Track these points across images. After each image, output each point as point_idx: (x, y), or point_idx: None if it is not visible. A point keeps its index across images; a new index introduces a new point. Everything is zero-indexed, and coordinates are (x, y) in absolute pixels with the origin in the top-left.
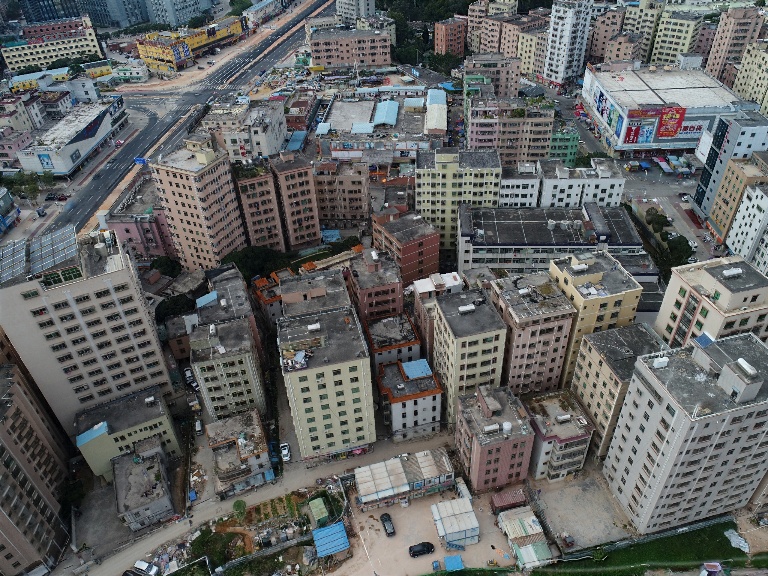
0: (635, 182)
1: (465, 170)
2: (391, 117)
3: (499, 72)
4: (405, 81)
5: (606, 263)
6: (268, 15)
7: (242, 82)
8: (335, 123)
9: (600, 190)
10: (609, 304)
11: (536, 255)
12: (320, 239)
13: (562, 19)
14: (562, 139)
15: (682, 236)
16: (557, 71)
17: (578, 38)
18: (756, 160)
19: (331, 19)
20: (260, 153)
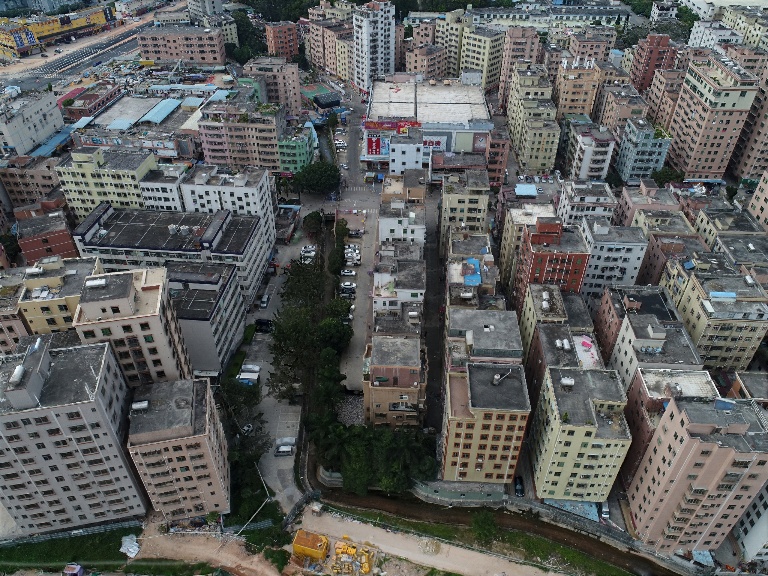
0: (363, 193)
1: (101, 170)
2: (160, 115)
3: (276, 77)
4: (224, 80)
5: (91, 268)
6: (145, 7)
7: (73, 72)
8: (106, 118)
9: (236, 198)
10: (52, 308)
11: (147, 258)
12: (3, 231)
13: (360, 28)
14: (288, 146)
15: (337, 248)
16: (363, 79)
17: (380, 48)
18: (403, 177)
19: (180, 15)
20: (6, 143)
